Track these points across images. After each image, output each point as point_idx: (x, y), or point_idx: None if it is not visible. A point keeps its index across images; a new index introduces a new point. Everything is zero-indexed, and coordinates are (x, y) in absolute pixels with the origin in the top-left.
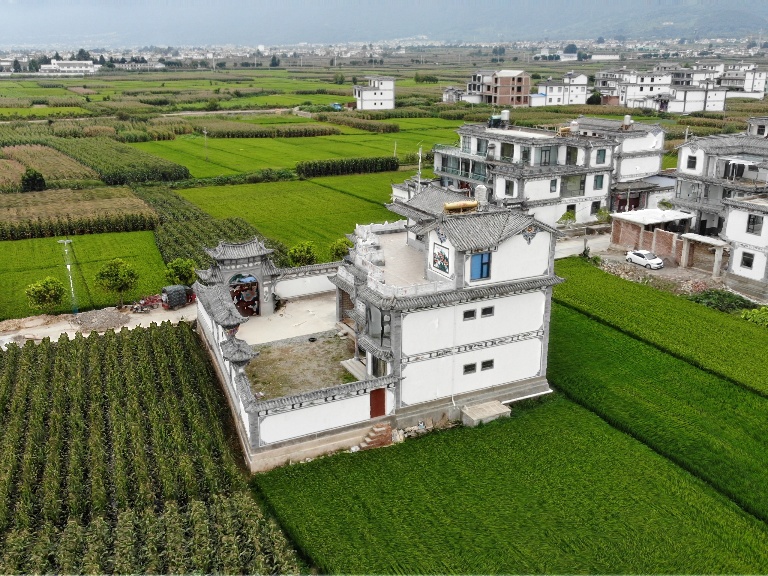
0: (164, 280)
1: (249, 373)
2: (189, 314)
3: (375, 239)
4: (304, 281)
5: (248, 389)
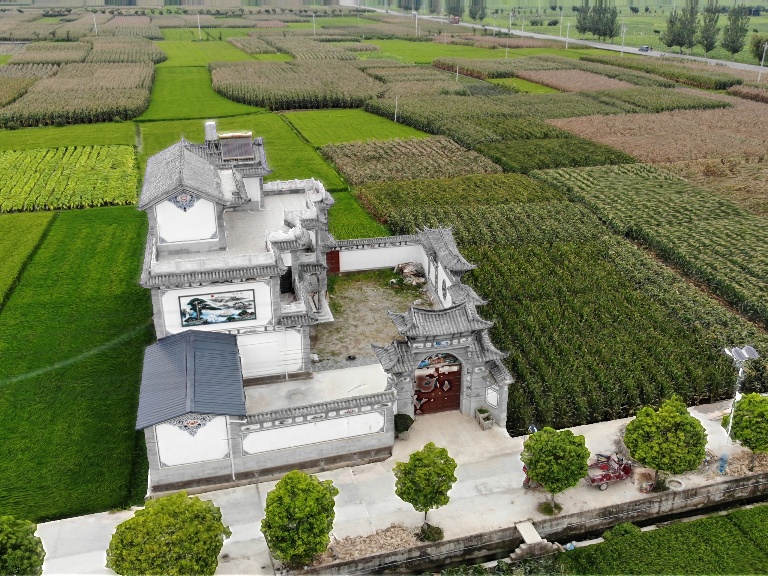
0: None
1: None
2: None
3: (271, 233)
4: None
5: None
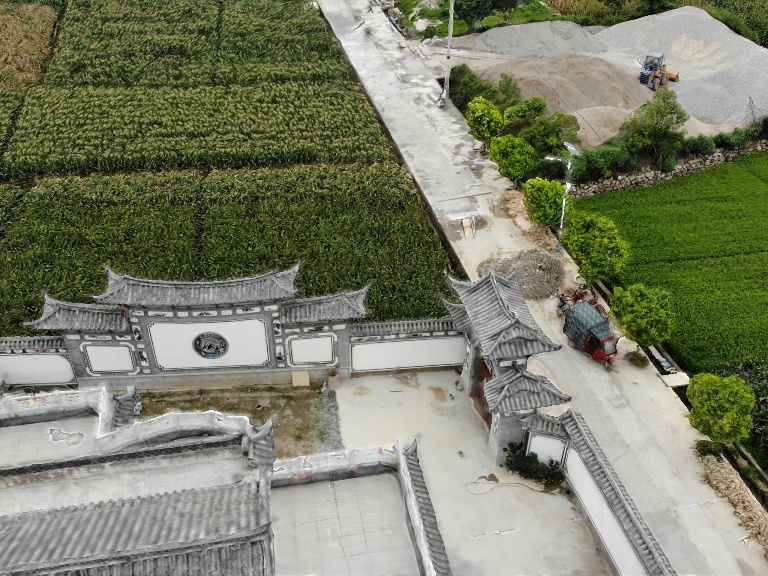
0: (762, 335)
1: (223, 405)
2: (548, 360)
3: None
4: (602, 505)
5: (14, 342)
